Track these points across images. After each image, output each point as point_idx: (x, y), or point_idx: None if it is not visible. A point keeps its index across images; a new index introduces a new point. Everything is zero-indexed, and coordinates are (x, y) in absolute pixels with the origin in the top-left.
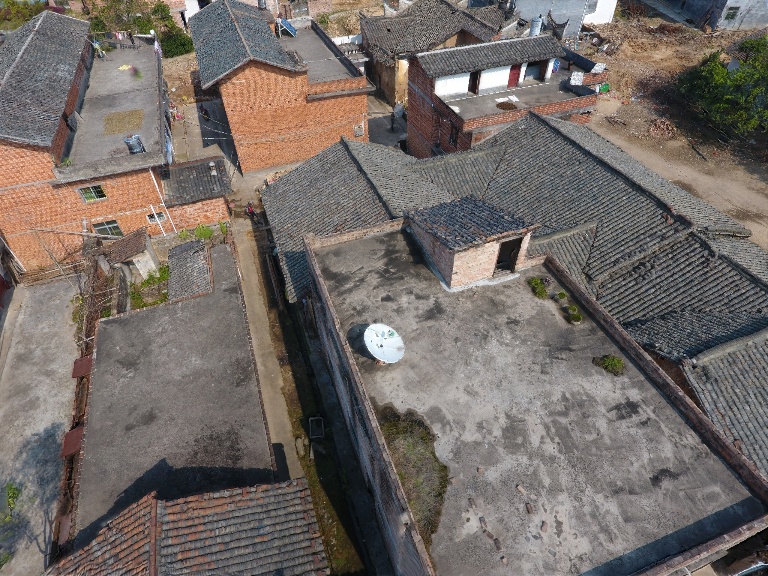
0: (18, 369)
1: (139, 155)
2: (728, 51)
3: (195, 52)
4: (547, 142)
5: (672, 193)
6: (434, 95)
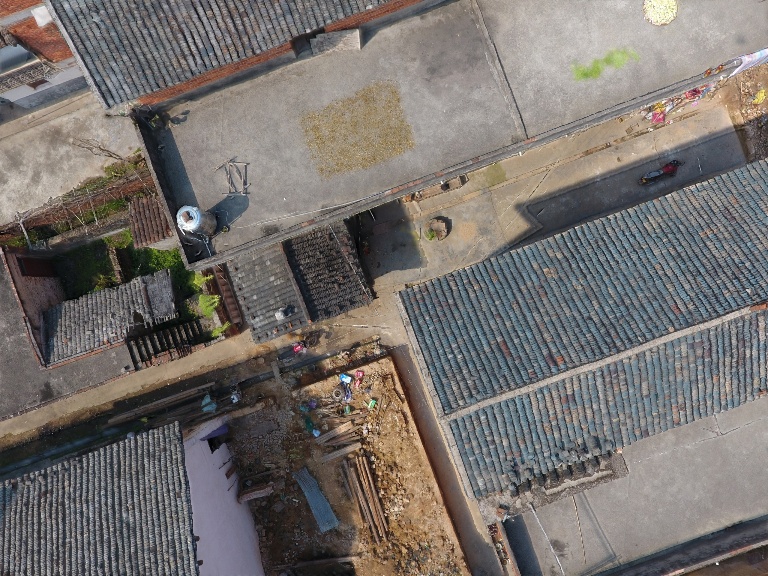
0: (40, 140)
1: (175, 235)
2: None
3: (633, 208)
4: None
5: None
6: None
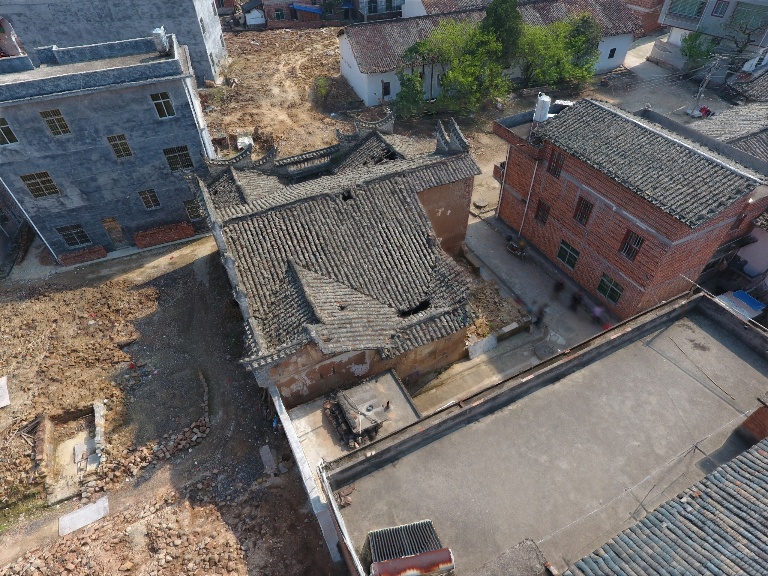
0: None
1: None
2: (370, 71)
3: None
4: (765, 145)
5: (759, 112)
6: (753, 203)
